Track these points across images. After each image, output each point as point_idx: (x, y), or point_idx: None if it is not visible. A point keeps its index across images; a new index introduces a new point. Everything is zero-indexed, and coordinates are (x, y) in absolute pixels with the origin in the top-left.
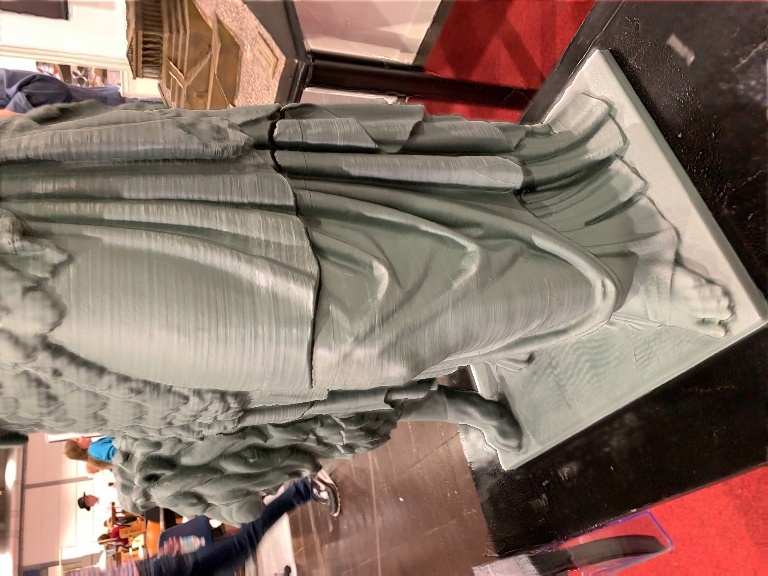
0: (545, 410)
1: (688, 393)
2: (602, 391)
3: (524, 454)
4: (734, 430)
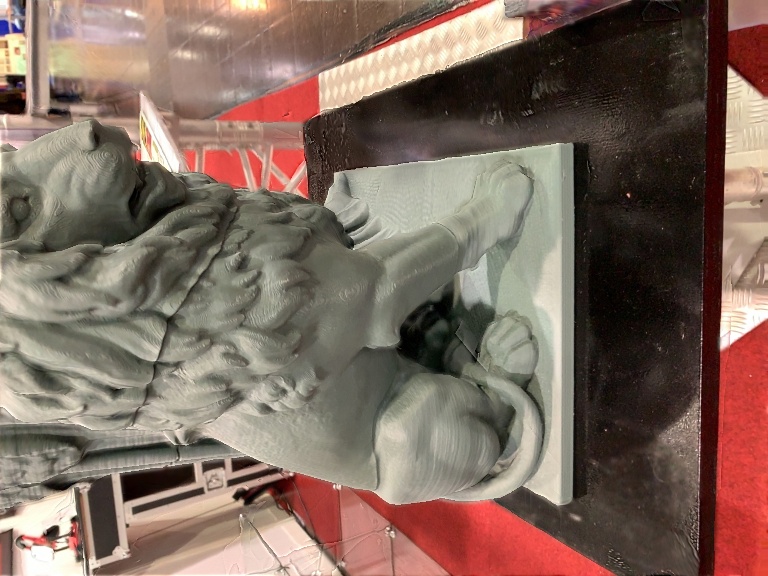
0: (453, 190)
1: (386, 153)
2: (406, 179)
3: (511, 155)
4: (371, 120)
